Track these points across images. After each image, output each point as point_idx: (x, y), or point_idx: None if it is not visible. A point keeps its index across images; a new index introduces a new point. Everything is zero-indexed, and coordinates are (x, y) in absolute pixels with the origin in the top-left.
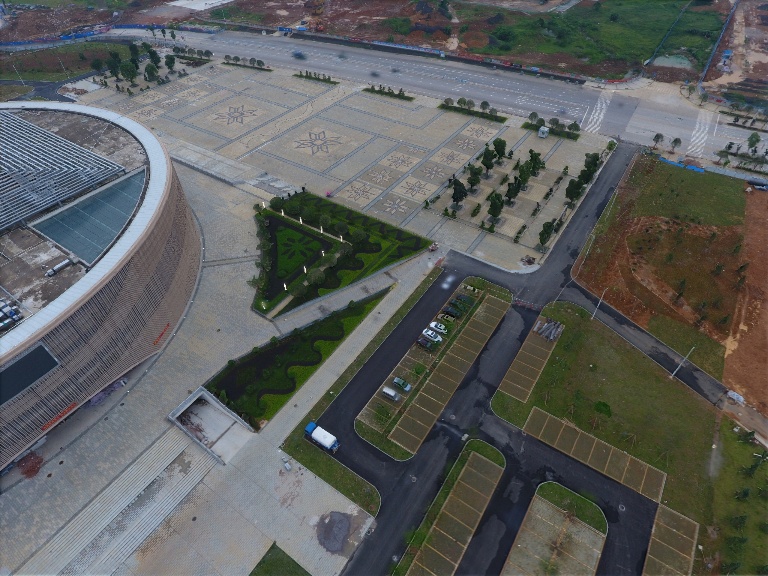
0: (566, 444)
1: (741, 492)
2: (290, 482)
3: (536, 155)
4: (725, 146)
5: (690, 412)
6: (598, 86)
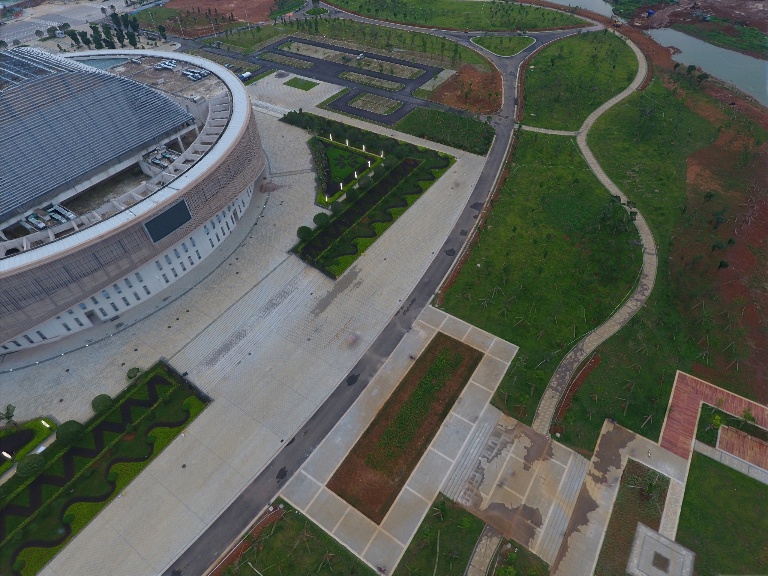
0: None
1: (291, 25)
2: (261, 83)
3: (95, 27)
4: (125, 3)
5: None
6: (16, 20)
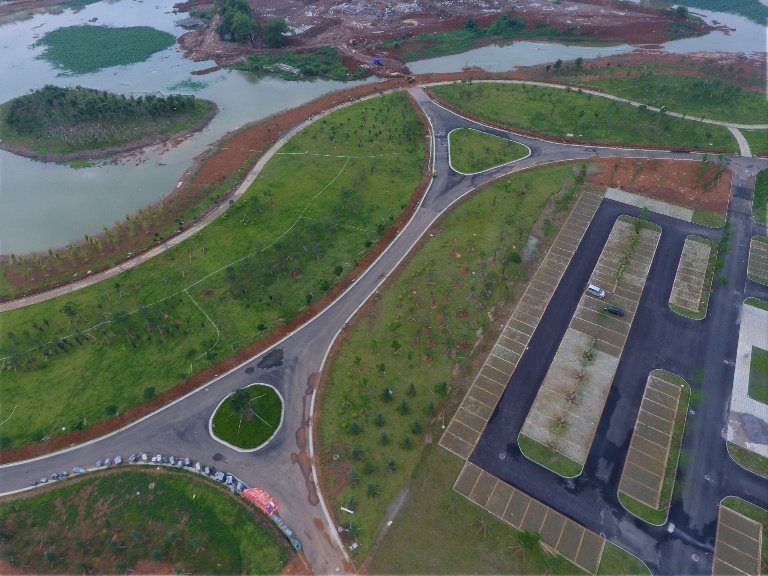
0: (554, 522)
1: None
2: None
3: None
4: None
5: (398, 571)
6: None
